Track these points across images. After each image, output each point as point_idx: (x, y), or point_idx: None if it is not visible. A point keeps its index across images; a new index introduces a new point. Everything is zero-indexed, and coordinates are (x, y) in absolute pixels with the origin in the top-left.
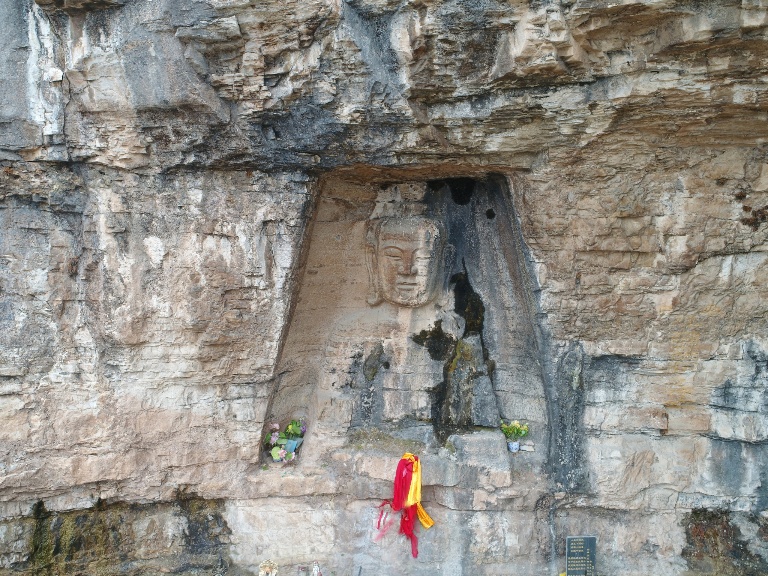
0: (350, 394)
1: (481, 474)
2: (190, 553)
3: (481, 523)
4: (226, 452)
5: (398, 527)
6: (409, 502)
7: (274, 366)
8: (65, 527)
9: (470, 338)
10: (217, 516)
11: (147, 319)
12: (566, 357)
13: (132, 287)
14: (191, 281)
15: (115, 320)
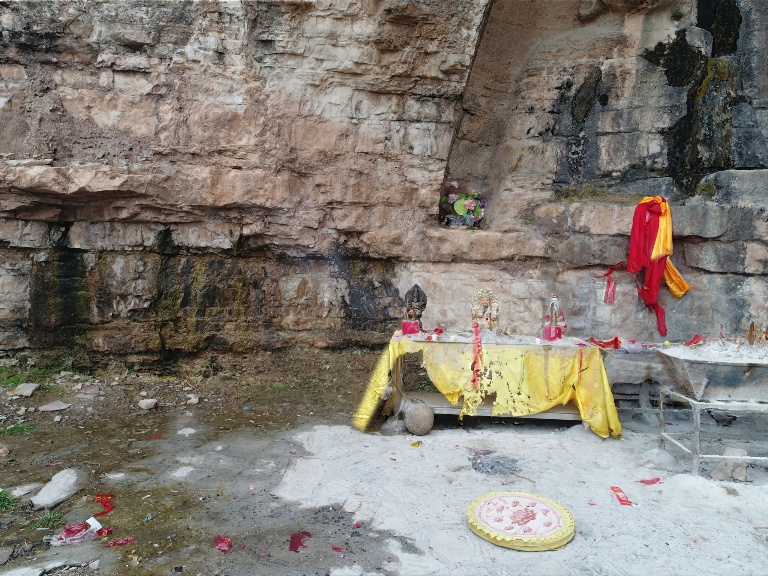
0: (553, 141)
1: (758, 219)
2: (351, 328)
3: (756, 291)
4: (401, 191)
5: (634, 298)
6: (655, 257)
7: (469, 71)
8: (196, 272)
9: (722, 57)
10: (385, 283)
11: None
12: None
13: None
14: None
15: None
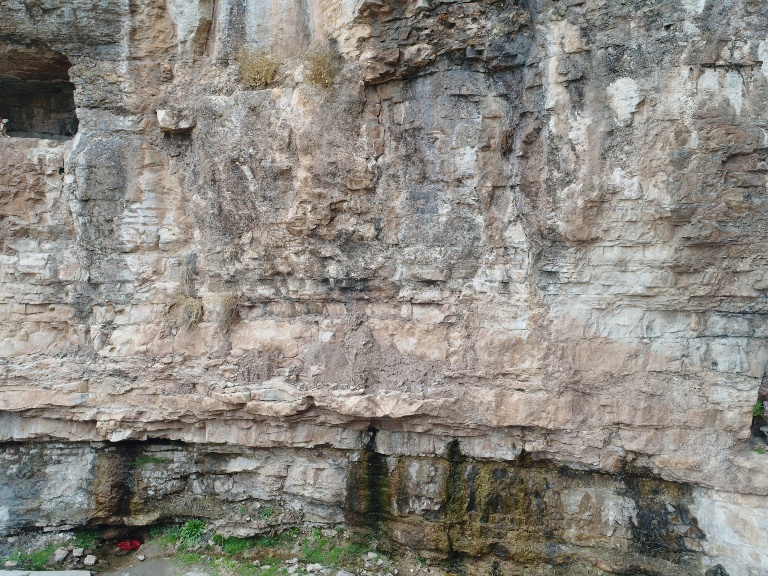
0: None
1: None
2: (639, 552)
3: None
4: (701, 415)
5: None
6: None
7: None
8: (481, 479)
9: None
10: (680, 508)
11: (603, 204)
12: None
13: (587, 157)
14: (675, 142)
15: (561, 204)
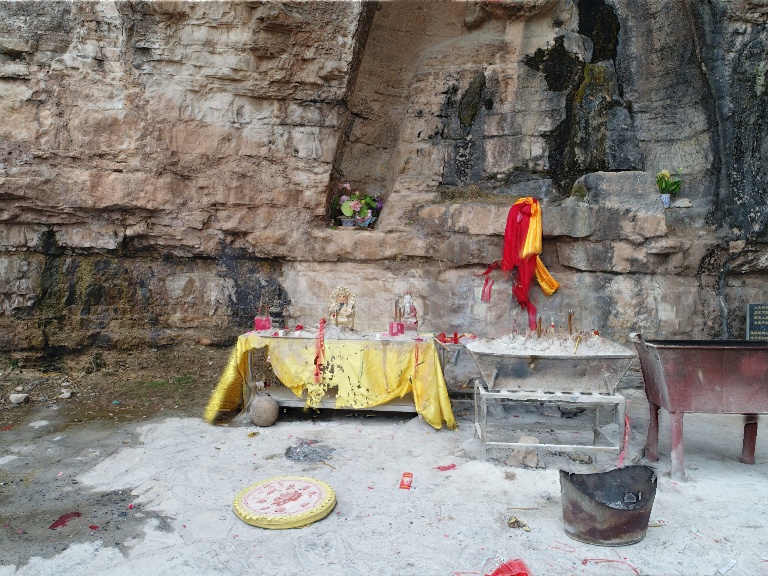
0: (441, 144)
1: (624, 219)
2: (238, 326)
3: (623, 289)
4: (285, 193)
5: (509, 296)
6: (525, 256)
7: (348, 76)
8: (81, 271)
9: (601, 63)
10: (272, 282)
11: None
12: (746, 50)
13: None
14: None
15: None
